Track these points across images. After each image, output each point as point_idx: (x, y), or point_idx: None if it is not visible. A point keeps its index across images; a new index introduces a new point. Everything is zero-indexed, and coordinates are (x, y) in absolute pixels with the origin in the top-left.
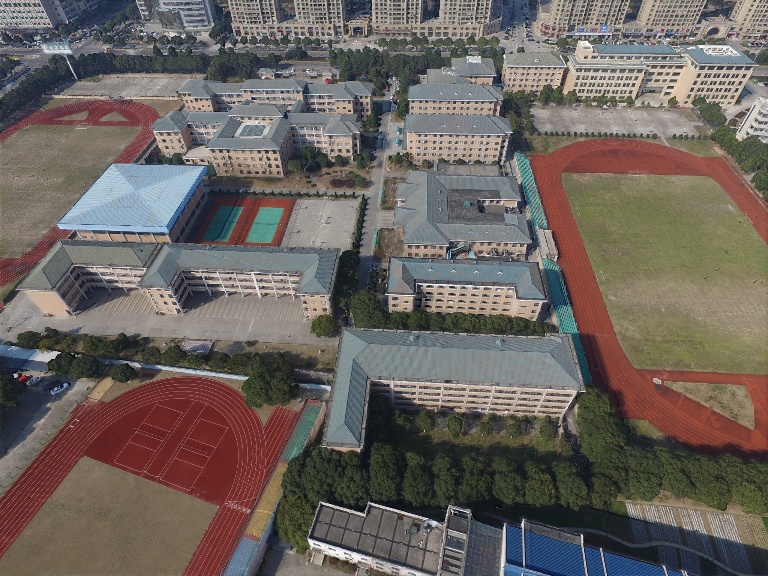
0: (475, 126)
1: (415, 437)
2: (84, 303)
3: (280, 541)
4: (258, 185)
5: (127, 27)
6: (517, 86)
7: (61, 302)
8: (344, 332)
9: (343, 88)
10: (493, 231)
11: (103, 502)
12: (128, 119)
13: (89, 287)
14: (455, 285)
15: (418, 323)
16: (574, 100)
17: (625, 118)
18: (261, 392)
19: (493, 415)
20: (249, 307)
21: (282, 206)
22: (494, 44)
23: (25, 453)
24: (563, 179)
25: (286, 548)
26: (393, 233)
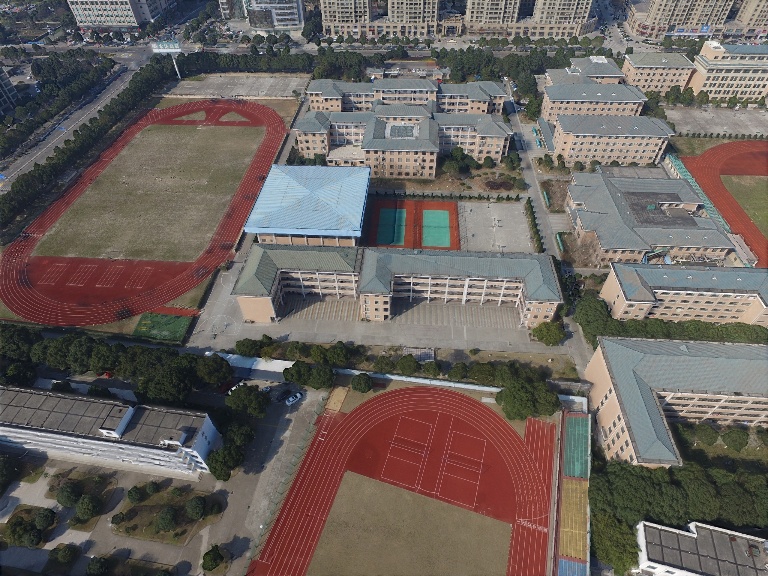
0: (636, 127)
1: (691, 451)
2: (281, 309)
3: (598, 562)
4: (412, 187)
5: (210, 26)
6: (640, 87)
7: (270, 308)
8: (603, 341)
9: (478, 88)
10: (694, 235)
11: (388, 520)
12: (249, 119)
13: (283, 292)
14: (693, 292)
15: (662, 331)
16: (705, 101)
17: (760, 119)
18: (530, 404)
19: (762, 428)
20: (455, 314)
21: (445, 209)
22: (598, 44)
23: (284, 467)
24: (724, 182)
25: (602, 570)
26: (572, 237)
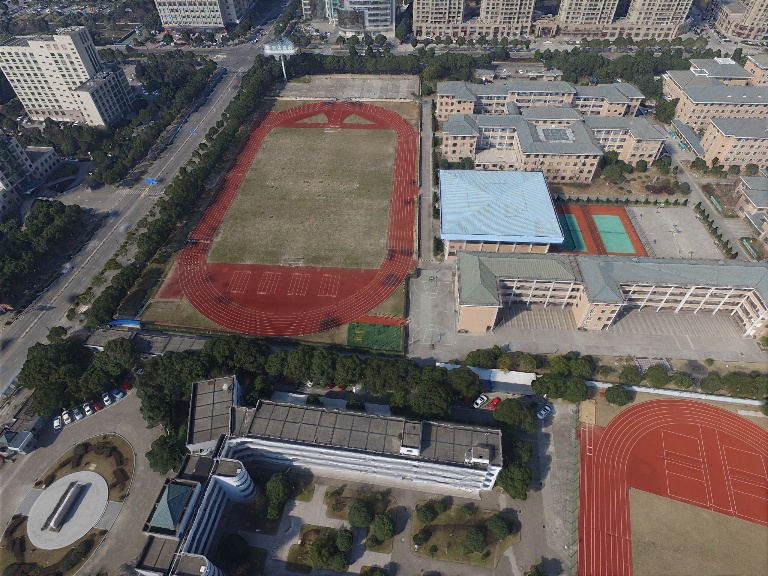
0: None
1: None
2: None
3: None
4: (572, 191)
5: (294, 27)
6: None
7: (492, 318)
8: None
9: (616, 90)
10: None
11: (696, 540)
12: (373, 122)
13: None
14: None
15: None
16: None
17: None
18: None
19: None
20: (671, 322)
21: (615, 214)
22: (703, 45)
23: (563, 484)
24: None
25: None
26: (758, 243)
